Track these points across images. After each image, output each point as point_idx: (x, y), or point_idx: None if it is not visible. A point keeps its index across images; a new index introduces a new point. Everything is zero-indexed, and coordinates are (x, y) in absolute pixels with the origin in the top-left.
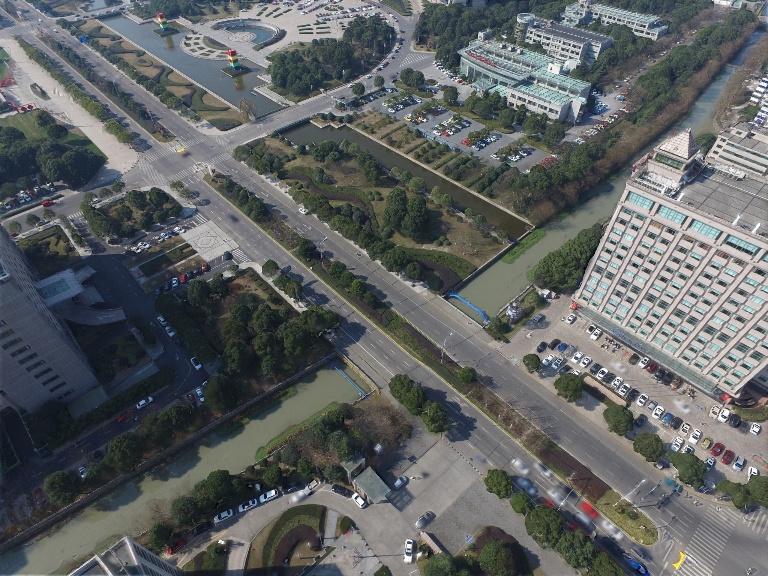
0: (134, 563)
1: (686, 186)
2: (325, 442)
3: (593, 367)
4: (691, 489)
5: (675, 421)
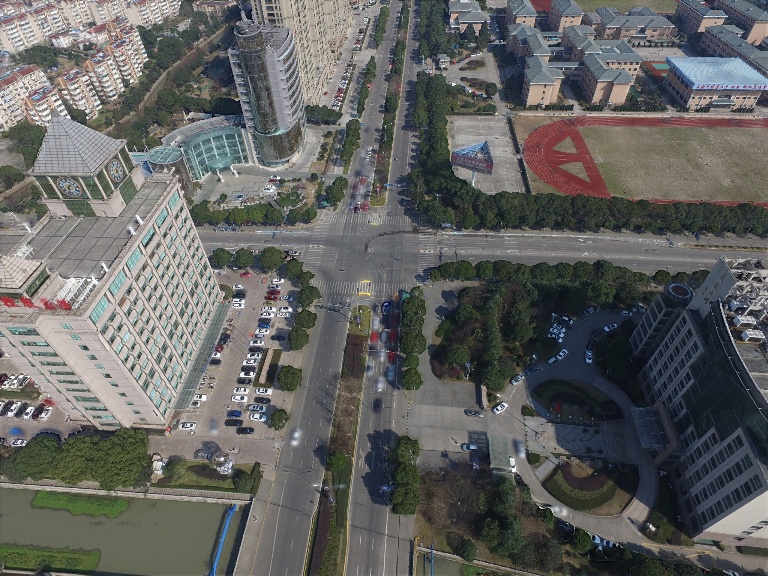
0: (760, 464)
1: (66, 277)
2: (518, 514)
3: (245, 382)
4: (313, 302)
5: (265, 321)
